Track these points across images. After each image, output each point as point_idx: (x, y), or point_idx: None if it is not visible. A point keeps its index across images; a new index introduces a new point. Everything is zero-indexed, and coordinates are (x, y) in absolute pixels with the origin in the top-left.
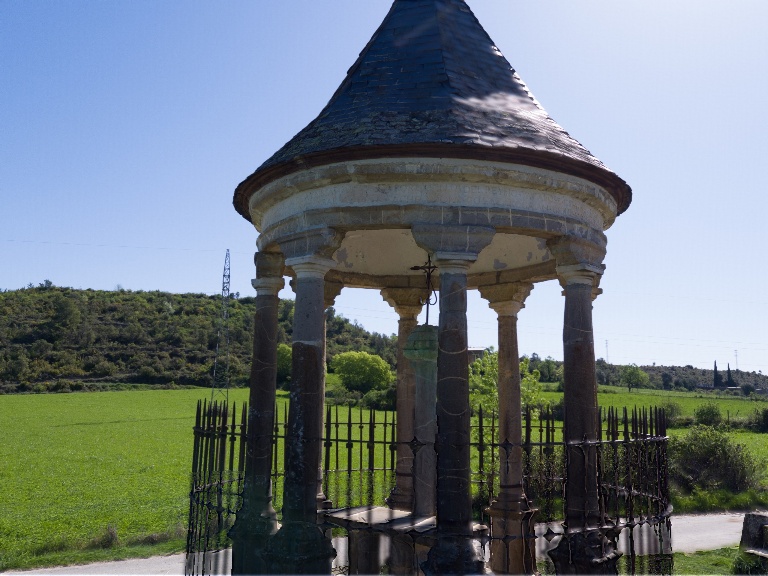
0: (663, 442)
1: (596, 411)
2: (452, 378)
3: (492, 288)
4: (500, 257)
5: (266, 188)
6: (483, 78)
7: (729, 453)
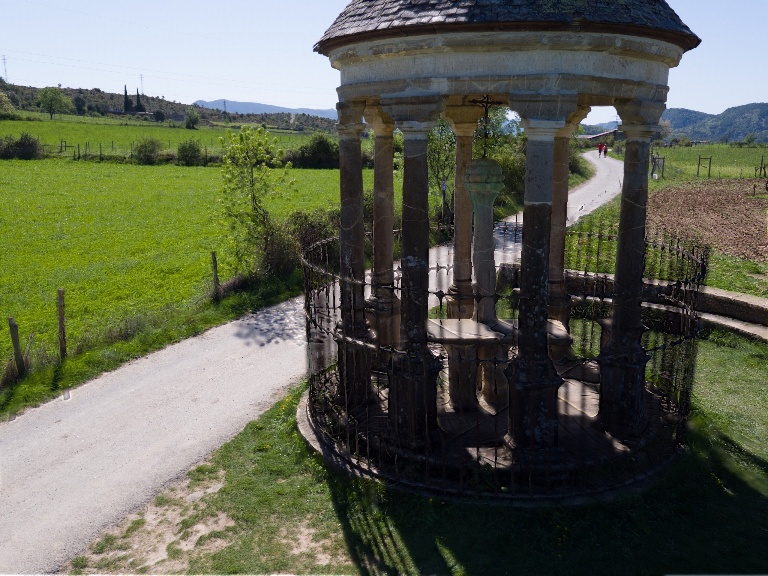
0: None
1: None
2: None
3: (459, 109)
4: None
5: (503, 35)
6: None
7: None
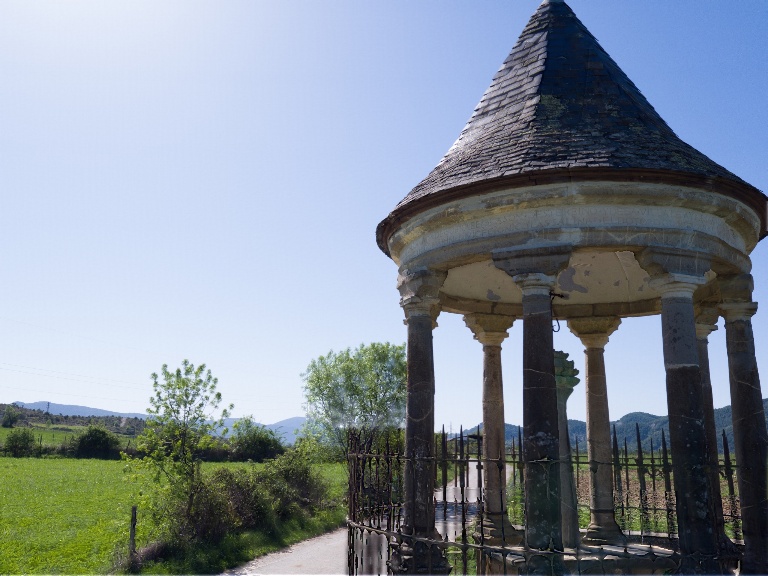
0: None
1: None
2: None
3: (488, 317)
4: (494, 289)
5: (642, 186)
6: None
7: (314, 475)
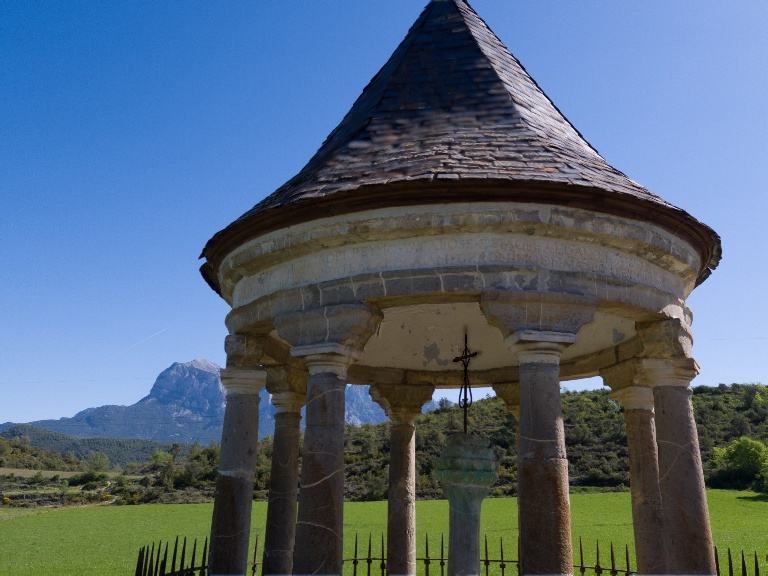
0: None
1: (702, 571)
2: (300, 523)
3: (612, 370)
4: (617, 325)
5: None
6: (434, 105)
7: None
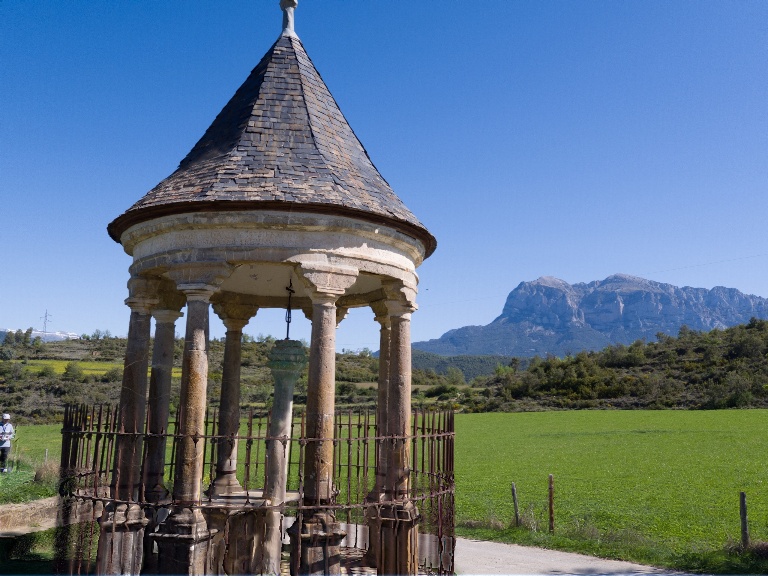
0: (193, 439)
1: (313, 412)
2: None
3: None
4: None
5: None
6: None
7: None
